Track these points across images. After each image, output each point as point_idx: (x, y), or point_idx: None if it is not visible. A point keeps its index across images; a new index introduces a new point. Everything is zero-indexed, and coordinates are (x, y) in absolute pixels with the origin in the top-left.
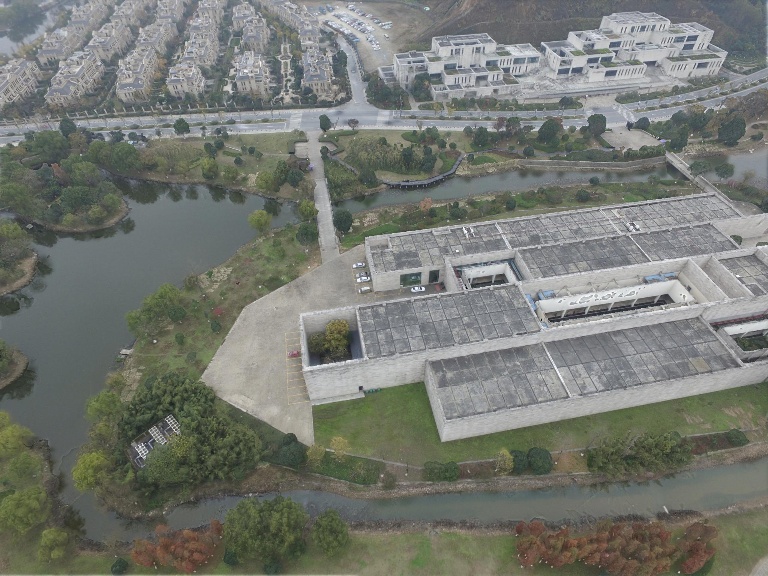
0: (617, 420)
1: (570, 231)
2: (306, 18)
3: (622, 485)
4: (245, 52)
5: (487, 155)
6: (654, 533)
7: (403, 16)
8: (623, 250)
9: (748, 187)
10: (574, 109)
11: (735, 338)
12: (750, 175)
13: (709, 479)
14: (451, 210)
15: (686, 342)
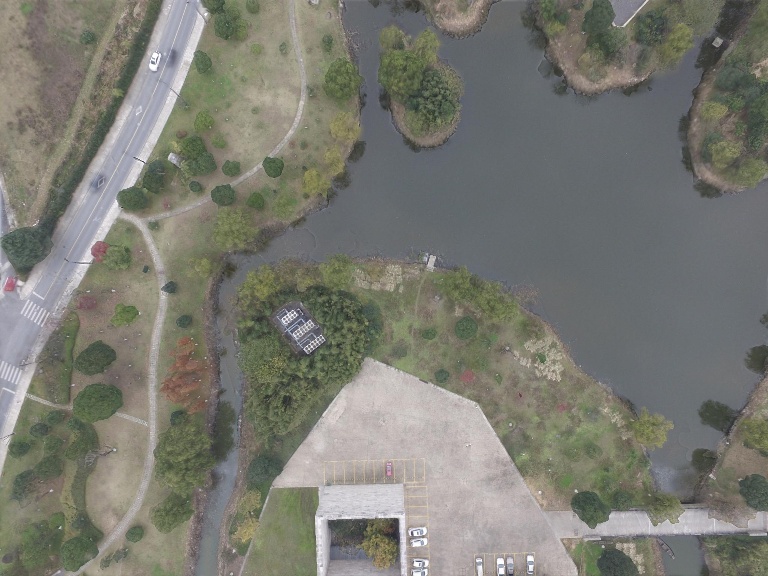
0: None
1: None
2: None
3: None
4: None
5: None
6: None
7: None
8: None
9: None
10: None
11: None
12: None
13: None
14: None
15: None
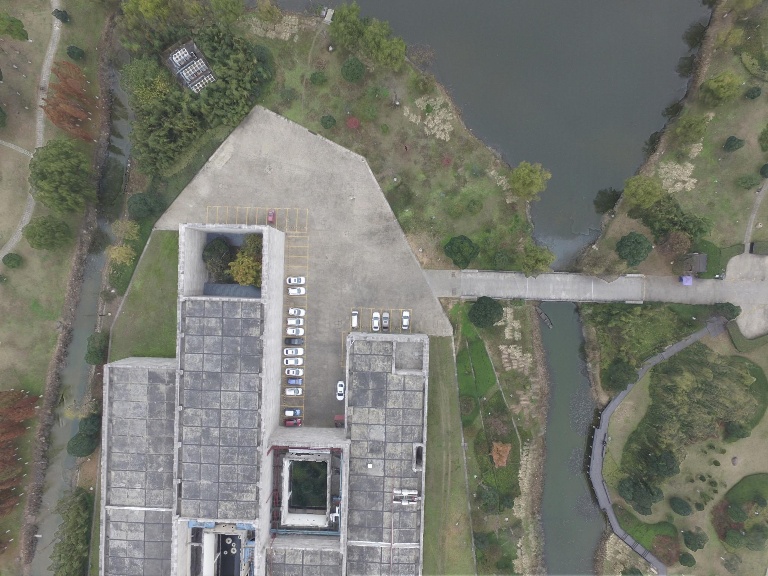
0: None
1: None
2: None
3: None
4: None
5: None
6: None
7: None
8: None
9: None
10: None
11: None
12: None
13: None
14: (494, 490)
15: None
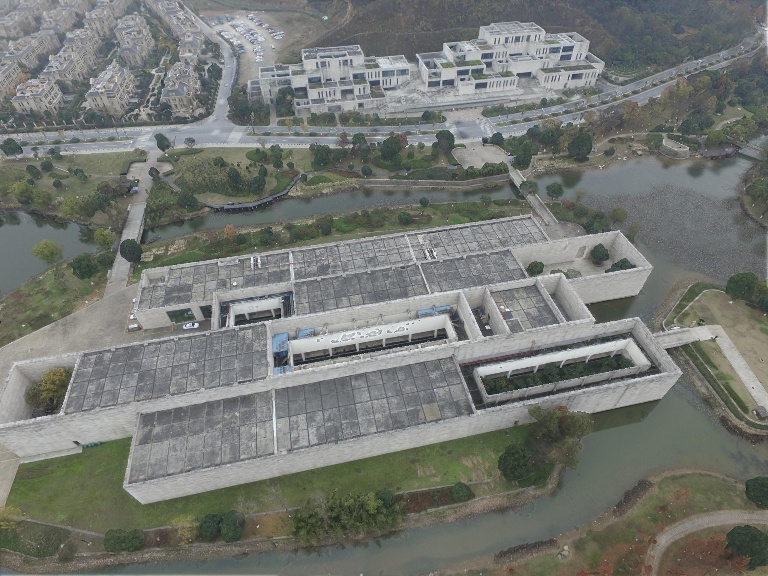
0: (343, 474)
1: (364, 260)
2: (188, 29)
3: (326, 549)
4: (109, 66)
5: (325, 175)
6: None
7: (299, 26)
8: (406, 281)
9: (577, 207)
10: (436, 123)
11: (503, 376)
12: (581, 194)
13: (422, 540)
14: None
15: (427, 386)
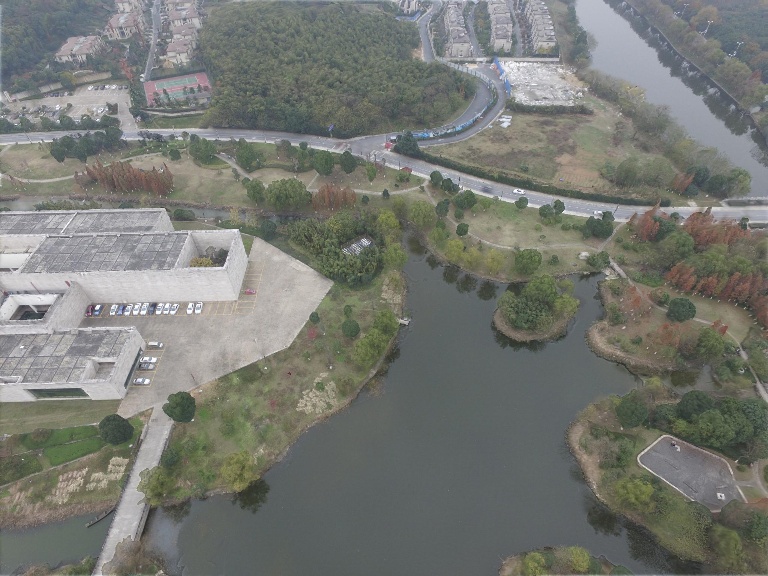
0: None
1: None
2: None
3: None
4: None
5: None
6: (104, 173)
7: None
8: None
9: None
10: None
11: None
12: None
13: None
14: None
15: None
